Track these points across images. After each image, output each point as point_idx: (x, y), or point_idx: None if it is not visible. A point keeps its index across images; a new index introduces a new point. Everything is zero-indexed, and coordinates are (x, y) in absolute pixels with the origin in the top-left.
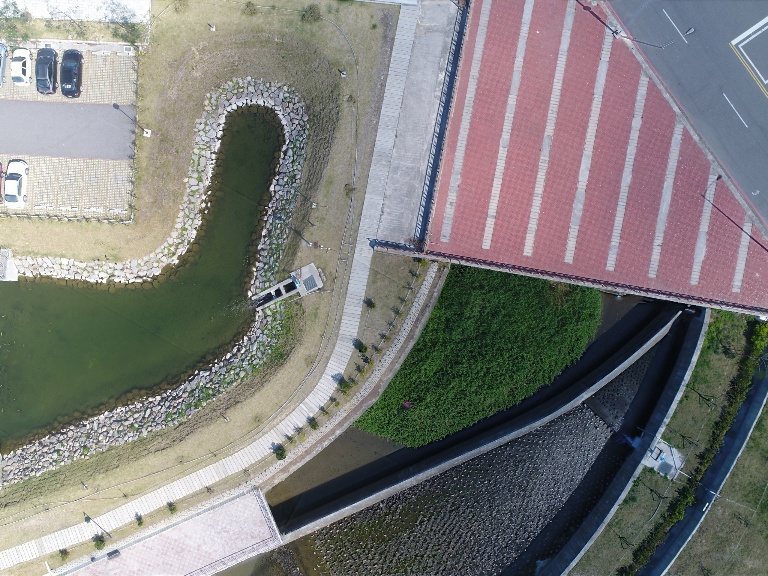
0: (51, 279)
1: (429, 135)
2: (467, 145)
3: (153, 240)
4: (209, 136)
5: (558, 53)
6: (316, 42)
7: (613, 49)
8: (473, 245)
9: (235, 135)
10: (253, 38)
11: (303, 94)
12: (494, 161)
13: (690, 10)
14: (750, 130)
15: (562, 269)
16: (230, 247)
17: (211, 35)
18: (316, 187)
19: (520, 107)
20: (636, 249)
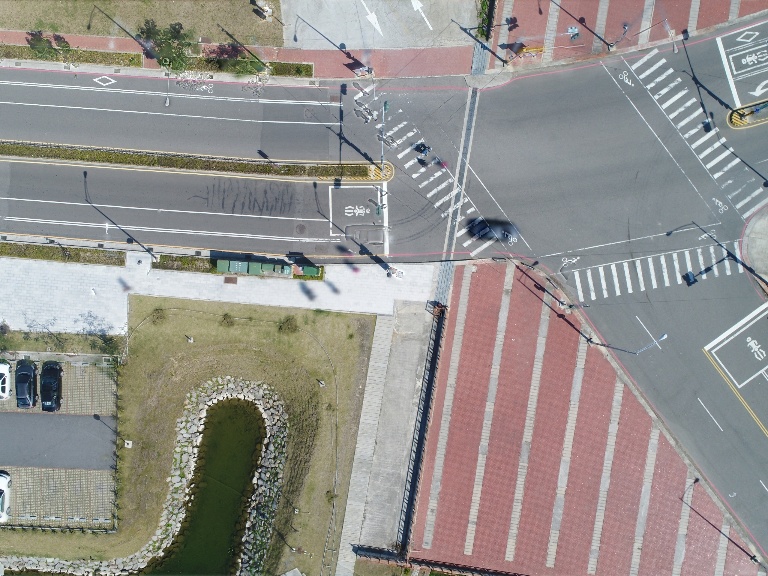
0: (37, 572)
1: (408, 441)
2: (446, 452)
3: (137, 541)
4: (190, 432)
5: (534, 360)
6: (294, 353)
7: (588, 356)
8: (455, 551)
9: (216, 426)
10: (231, 347)
11: (283, 394)
12: (473, 468)
13: (663, 316)
14: (725, 434)
15: (544, 573)
16: (215, 535)
17: (189, 346)
18: (298, 492)
19: (498, 414)
20: (616, 553)
